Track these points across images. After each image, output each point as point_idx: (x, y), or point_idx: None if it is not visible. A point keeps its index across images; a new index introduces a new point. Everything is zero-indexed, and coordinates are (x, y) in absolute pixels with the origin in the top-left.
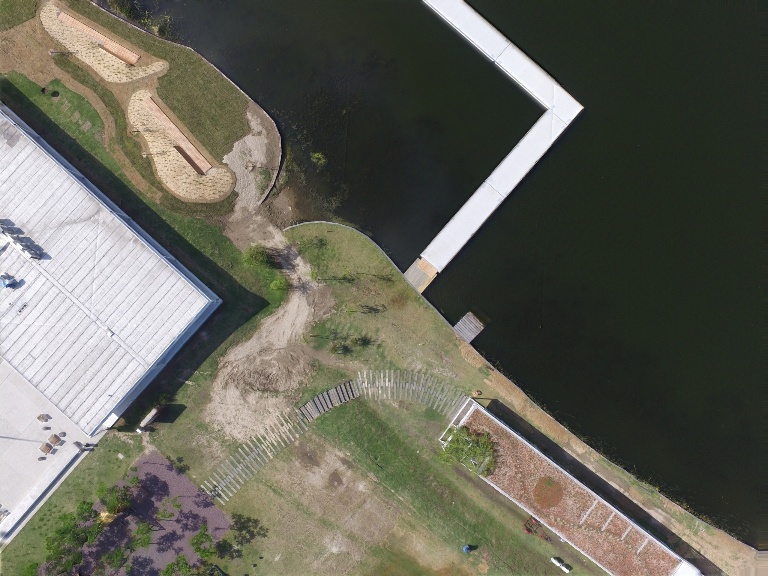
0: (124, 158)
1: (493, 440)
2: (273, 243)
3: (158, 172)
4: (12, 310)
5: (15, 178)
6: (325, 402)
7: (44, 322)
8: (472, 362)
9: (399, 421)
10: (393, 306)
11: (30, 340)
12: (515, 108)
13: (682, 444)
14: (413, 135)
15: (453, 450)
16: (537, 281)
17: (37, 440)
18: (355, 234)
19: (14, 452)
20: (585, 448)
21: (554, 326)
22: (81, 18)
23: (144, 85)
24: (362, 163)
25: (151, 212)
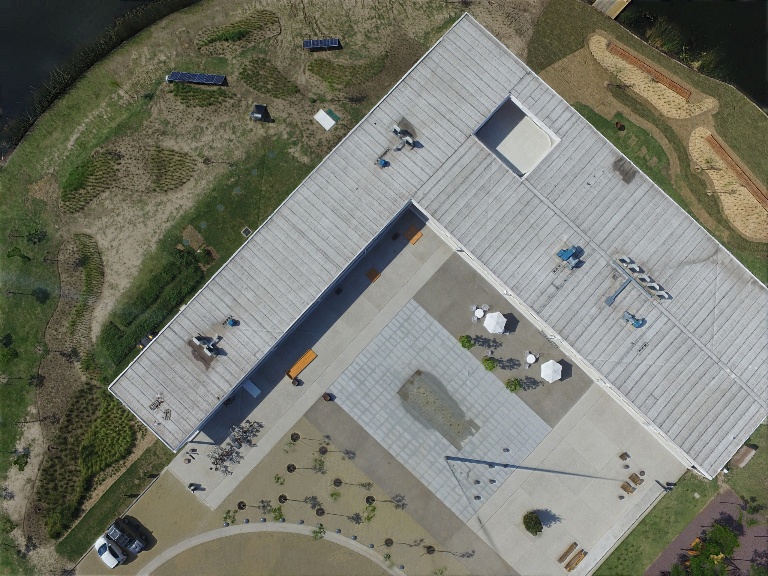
0: (690, 195)
1: None
2: None
3: (725, 211)
4: (633, 349)
5: (633, 215)
6: None
7: (665, 362)
8: None
9: None
10: None
11: (651, 380)
12: None
13: None
14: None
15: None
16: None
17: (615, 478)
18: None
19: (592, 490)
20: None
21: None
22: (630, 51)
23: (702, 122)
24: None
25: None
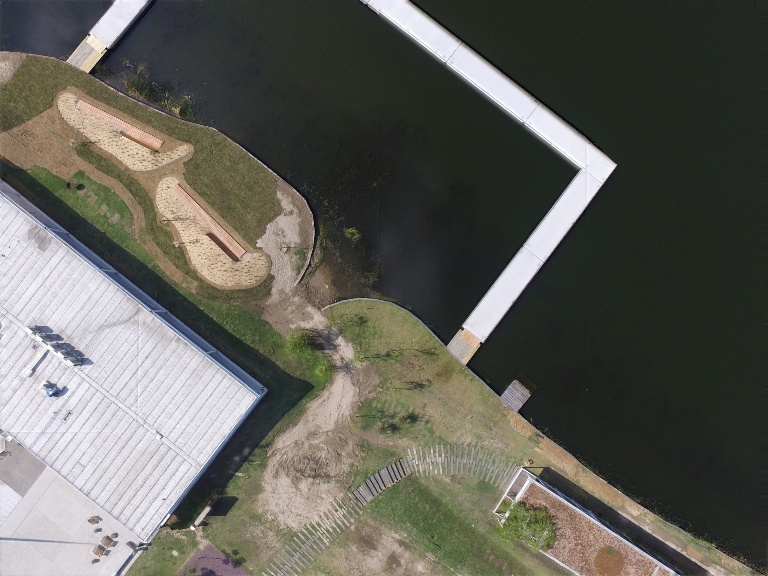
0: (156, 249)
1: (551, 514)
2: (313, 324)
3: (192, 261)
4: (57, 419)
5: (50, 283)
6: (377, 483)
7: (90, 429)
8: (522, 431)
9: (452, 496)
10: (438, 380)
11: (78, 448)
12: (548, 168)
13: (736, 498)
14: (446, 203)
15: (512, 528)
16: (581, 343)
17: (89, 542)
18: (395, 309)
19: (66, 556)
20: (640, 510)
21: (601, 388)
22: (100, 105)
23: (170, 171)
24: (397, 235)
25: (188, 303)
